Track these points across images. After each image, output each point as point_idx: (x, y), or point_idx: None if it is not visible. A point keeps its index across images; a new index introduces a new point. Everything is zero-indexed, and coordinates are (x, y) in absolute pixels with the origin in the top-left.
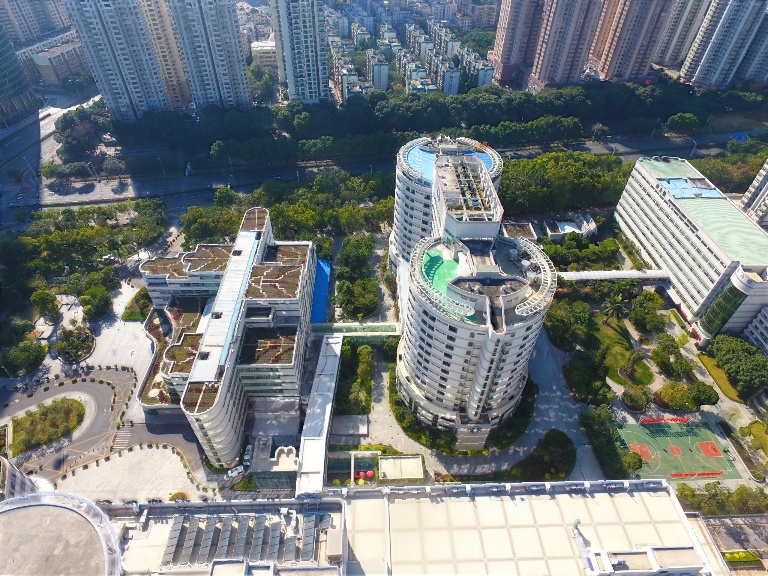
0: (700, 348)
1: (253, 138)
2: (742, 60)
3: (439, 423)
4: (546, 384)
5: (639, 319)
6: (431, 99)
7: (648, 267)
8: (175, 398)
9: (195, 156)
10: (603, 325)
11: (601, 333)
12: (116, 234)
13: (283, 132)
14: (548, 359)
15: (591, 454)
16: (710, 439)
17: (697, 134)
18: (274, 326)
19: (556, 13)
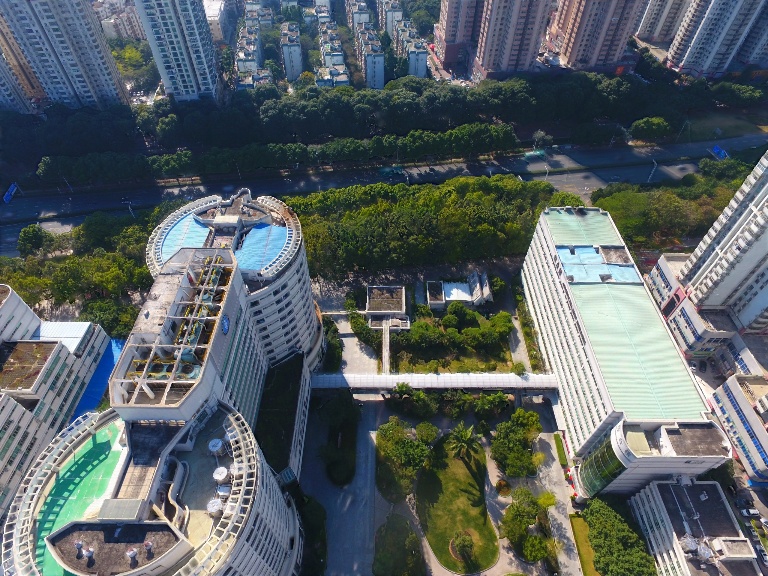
0: (576, 505)
1: (89, 154)
2: (746, 39)
3: None
4: (345, 561)
5: (498, 459)
6: (330, 98)
7: (542, 361)
8: None
9: (20, 176)
10: (454, 458)
11: (447, 473)
12: None
13: None
14: (363, 515)
15: None
16: None
17: (670, 142)
18: None
19: None
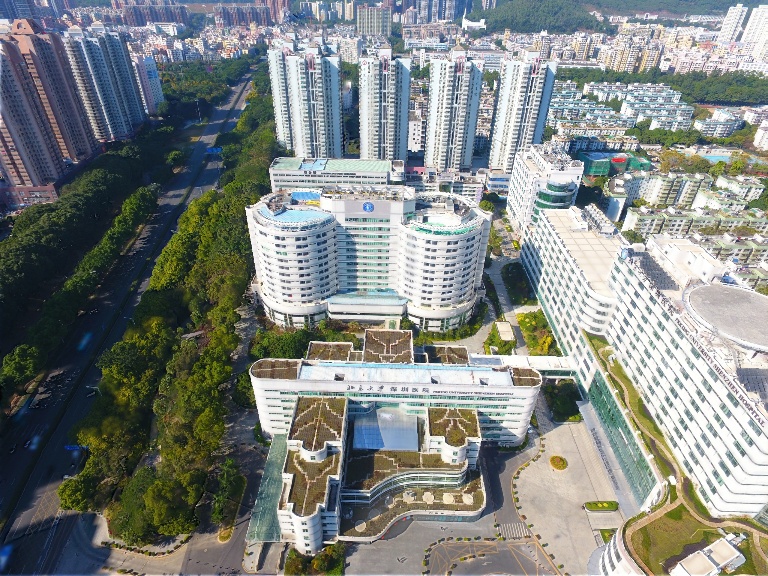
0: None
1: None
2: None
3: None
4: None
5: None
6: (20, 247)
7: None
8: (472, 476)
9: None
10: None
11: None
12: None
13: None
14: None
15: None
16: None
17: (185, 163)
18: None
19: (6, 118)
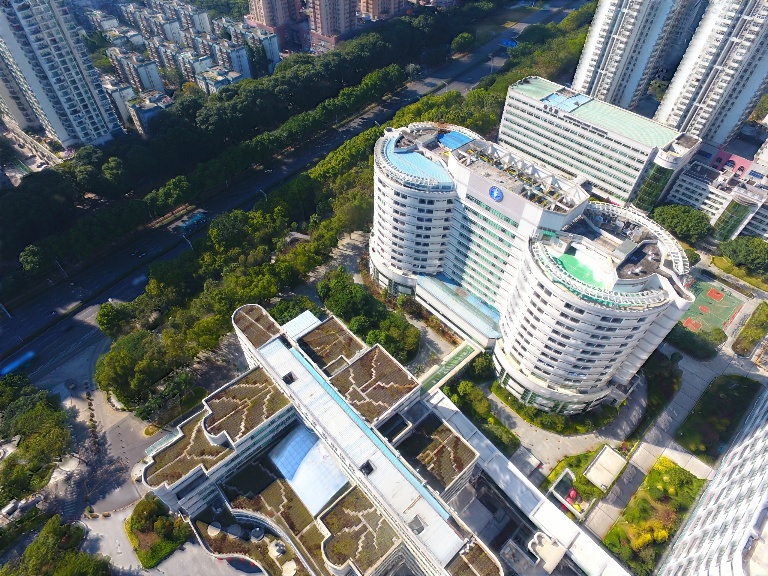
0: None
1: (79, 220)
2: None
3: (590, 406)
4: None
5: None
6: (253, 89)
7: None
8: None
9: (0, 284)
10: None
11: None
12: (13, 466)
13: (84, 194)
14: None
15: (673, 349)
16: (709, 288)
17: (473, 49)
18: (412, 430)
19: None
